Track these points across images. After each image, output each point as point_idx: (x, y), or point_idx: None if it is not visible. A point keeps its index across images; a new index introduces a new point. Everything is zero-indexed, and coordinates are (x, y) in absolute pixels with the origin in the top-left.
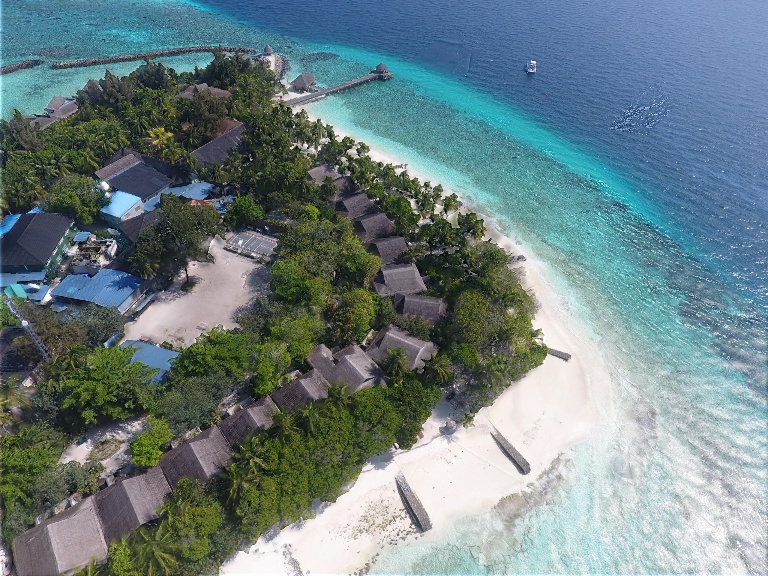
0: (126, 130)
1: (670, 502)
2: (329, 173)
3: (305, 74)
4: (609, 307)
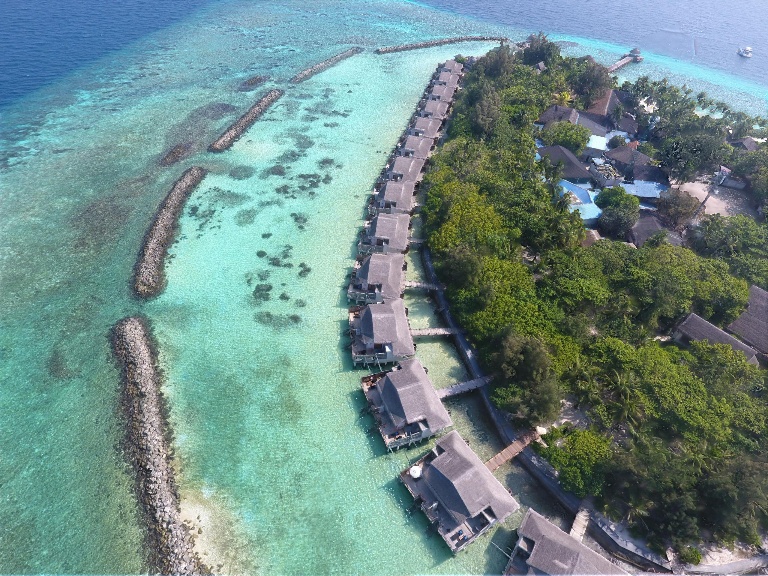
0: None
1: None
2: None
3: (591, 56)
4: None
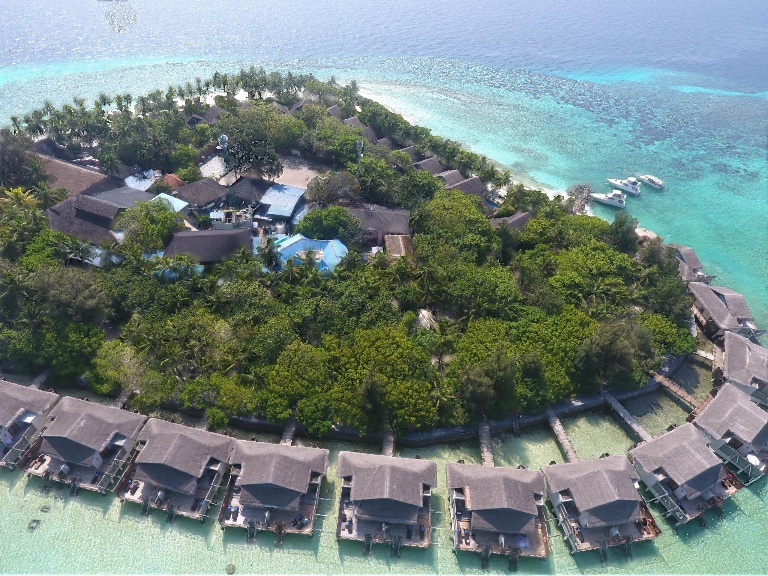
0: None
1: (389, 91)
2: None
3: None
4: None
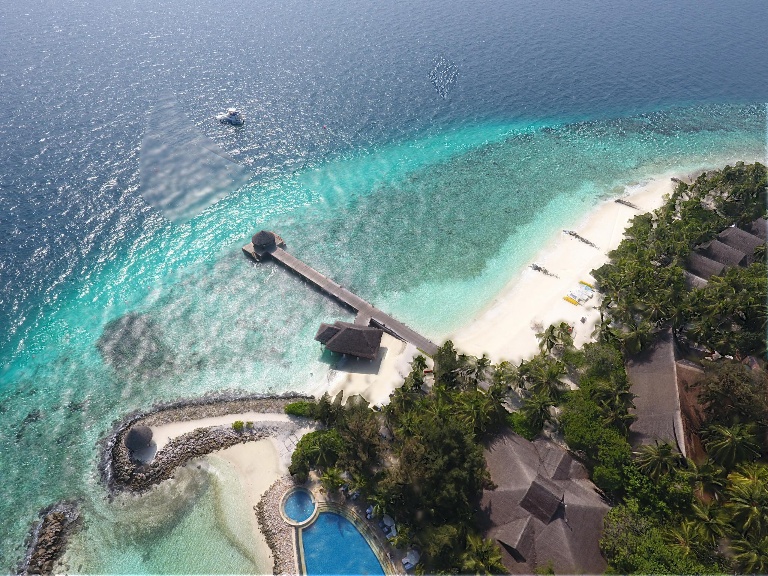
0: None
1: None
2: None
3: (351, 327)
4: (691, 156)
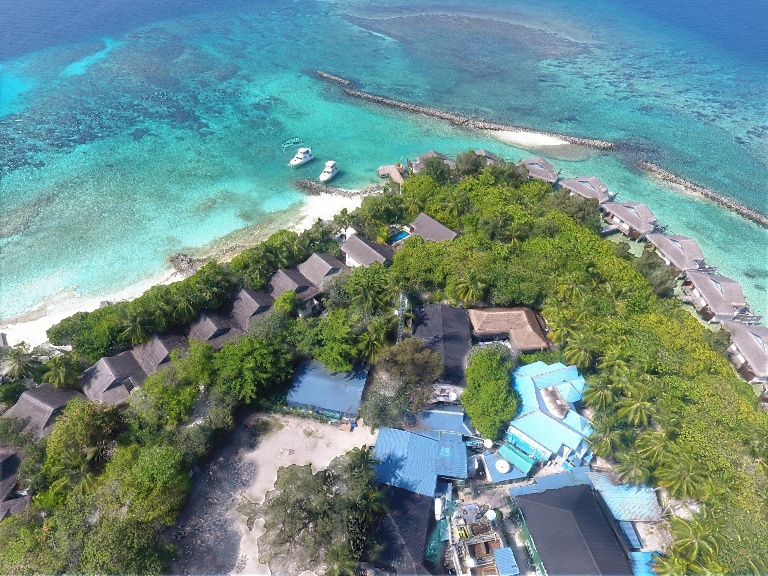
0: None
1: None
2: None
3: None
4: None
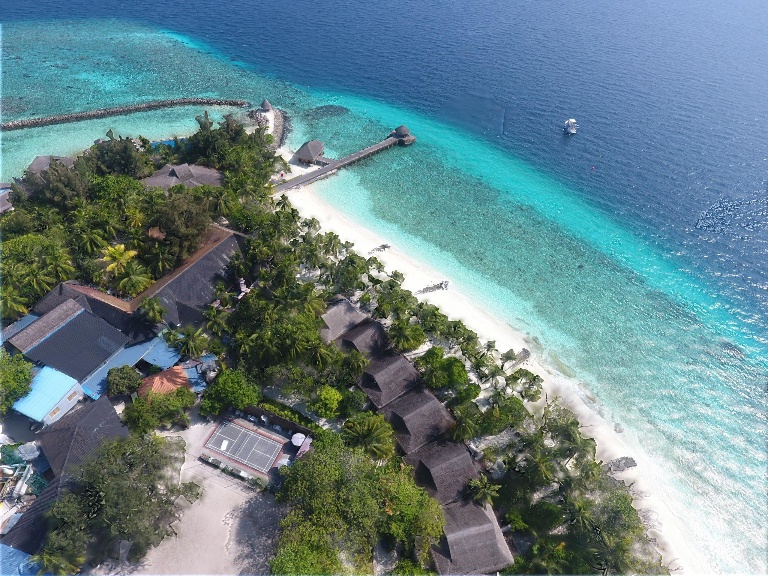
0: (72, 245)
1: None
2: (350, 314)
3: (312, 143)
4: None
